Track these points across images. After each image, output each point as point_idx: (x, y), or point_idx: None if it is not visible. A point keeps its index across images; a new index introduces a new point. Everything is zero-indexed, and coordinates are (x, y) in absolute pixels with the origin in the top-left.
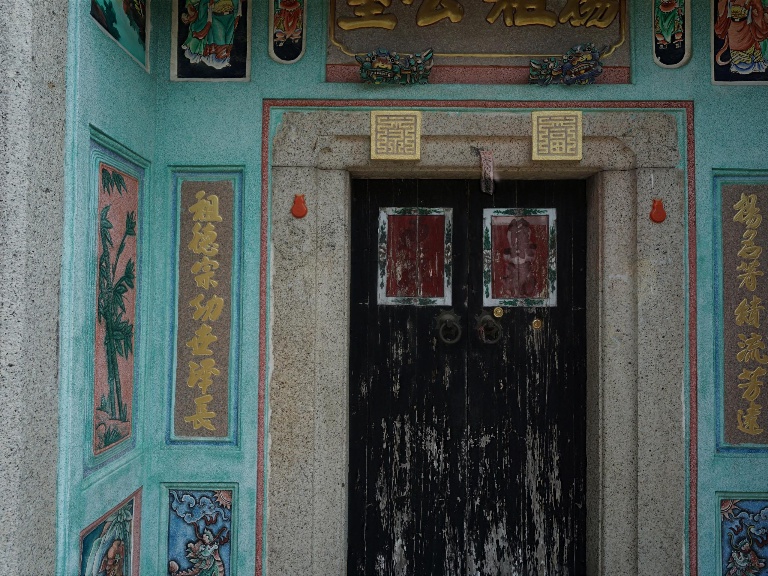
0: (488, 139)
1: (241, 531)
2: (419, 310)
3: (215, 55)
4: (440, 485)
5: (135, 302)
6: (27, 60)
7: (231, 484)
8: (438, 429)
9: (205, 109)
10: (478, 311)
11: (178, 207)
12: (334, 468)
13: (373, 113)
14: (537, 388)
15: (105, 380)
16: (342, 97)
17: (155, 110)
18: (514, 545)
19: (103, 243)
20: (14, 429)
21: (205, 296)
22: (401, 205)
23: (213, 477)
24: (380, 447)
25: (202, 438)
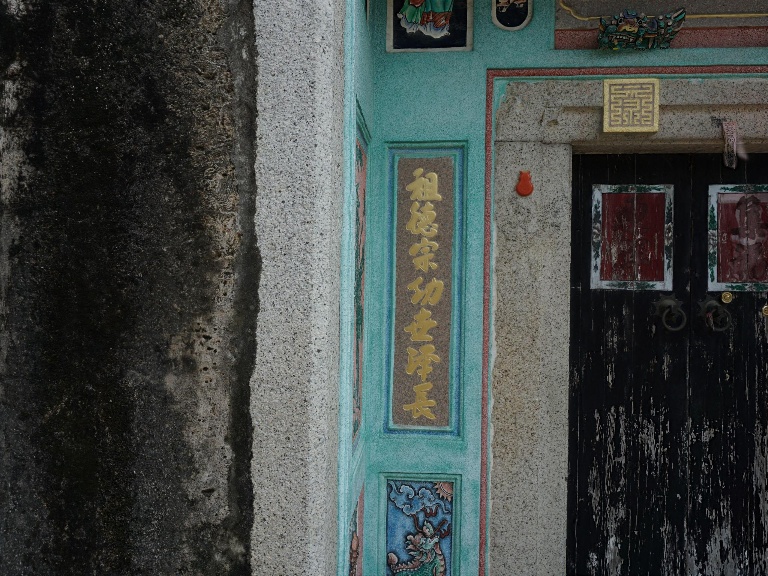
0: (732, 108)
1: (464, 525)
2: (636, 295)
3: (433, 23)
4: (658, 481)
5: (363, 285)
6: (330, 24)
7: (453, 476)
8: (656, 422)
9: (425, 81)
10: (702, 296)
11: (395, 186)
12: (558, 461)
13: (606, 82)
14: (767, 380)
15: (355, 366)
16: (574, 65)
17: (373, 83)
18: (740, 547)
19: (356, 222)
20: (321, 418)
21: (424, 279)
22: (617, 182)
23: (435, 468)
24: (593, 439)
25: (422, 427)
